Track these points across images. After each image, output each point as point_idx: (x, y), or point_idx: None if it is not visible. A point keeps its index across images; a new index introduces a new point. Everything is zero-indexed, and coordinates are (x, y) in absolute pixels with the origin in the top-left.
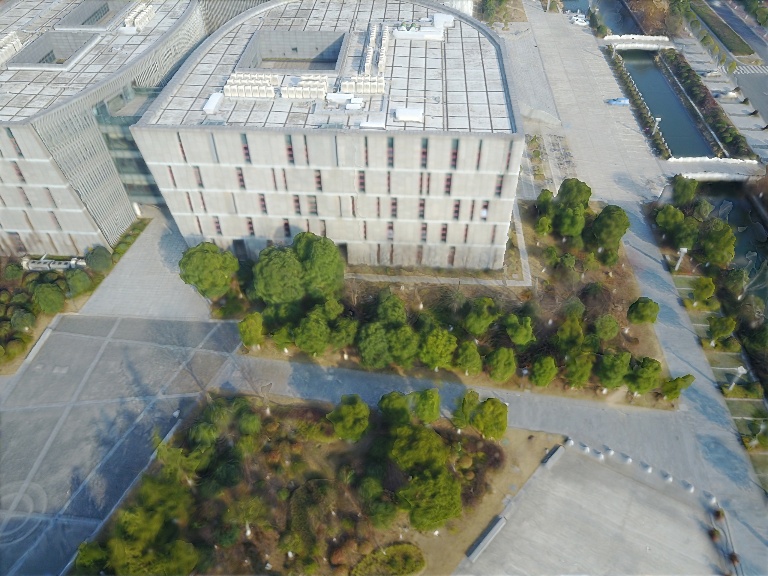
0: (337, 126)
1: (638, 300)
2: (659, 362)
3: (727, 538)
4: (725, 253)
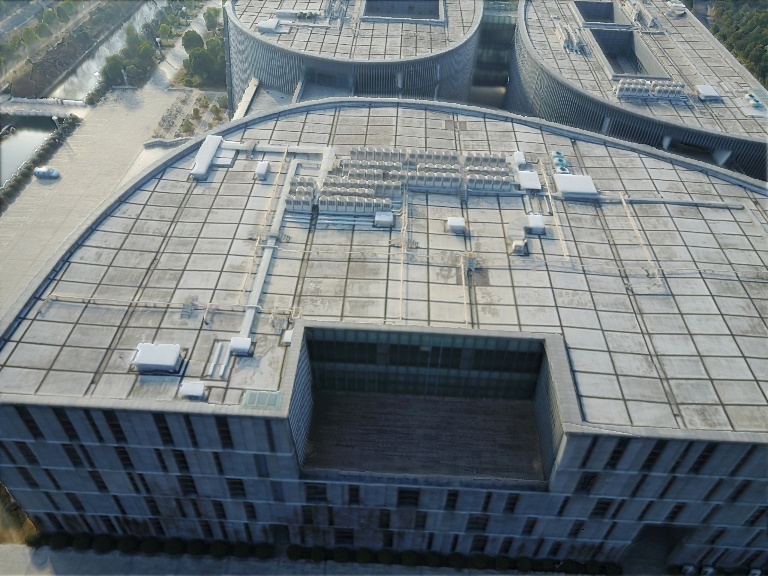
0: None
1: None
2: (223, 0)
3: None
4: None
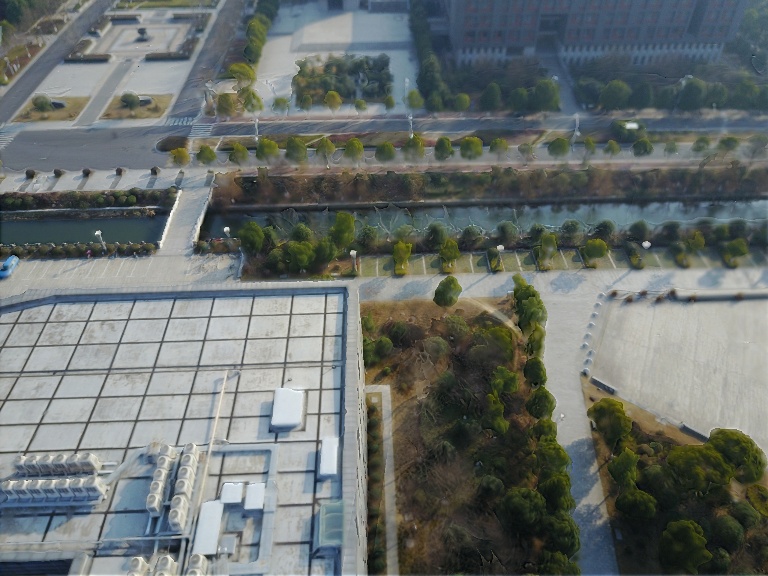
0: (336, 513)
1: (443, 289)
2: (524, 285)
3: (632, 293)
4: (354, 230)
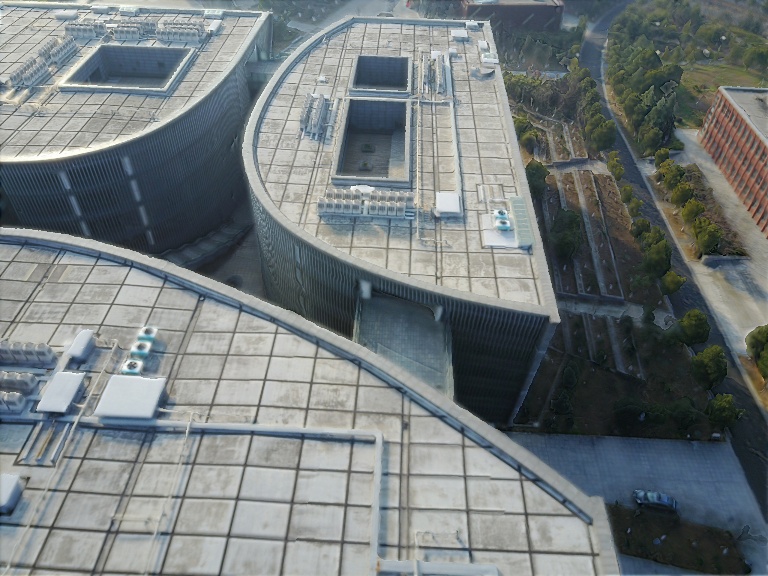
0: (125, 7)
1: None
2: None
3: None
4: None
